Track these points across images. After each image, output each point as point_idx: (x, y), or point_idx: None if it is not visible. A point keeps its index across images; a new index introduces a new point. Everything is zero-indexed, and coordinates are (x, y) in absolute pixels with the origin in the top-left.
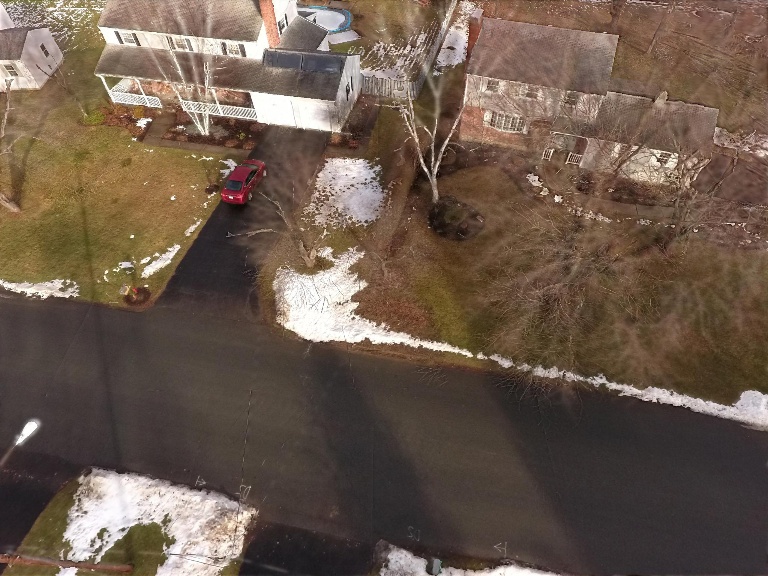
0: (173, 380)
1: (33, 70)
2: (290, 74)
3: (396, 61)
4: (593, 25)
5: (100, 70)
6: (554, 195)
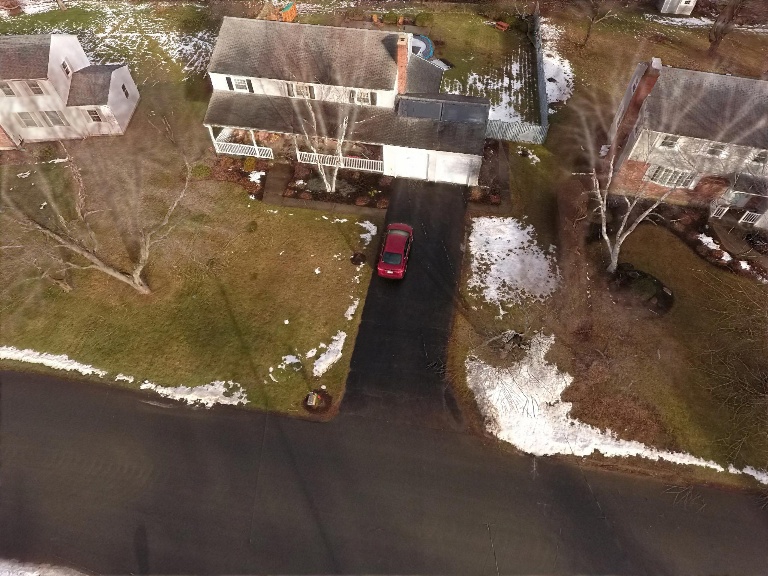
0: (393, 514)
1: (117, 114)
2: (428, 125)
3: (500, 96)
4: (689, 52)
5: (210, 120)
6: (738, 261)
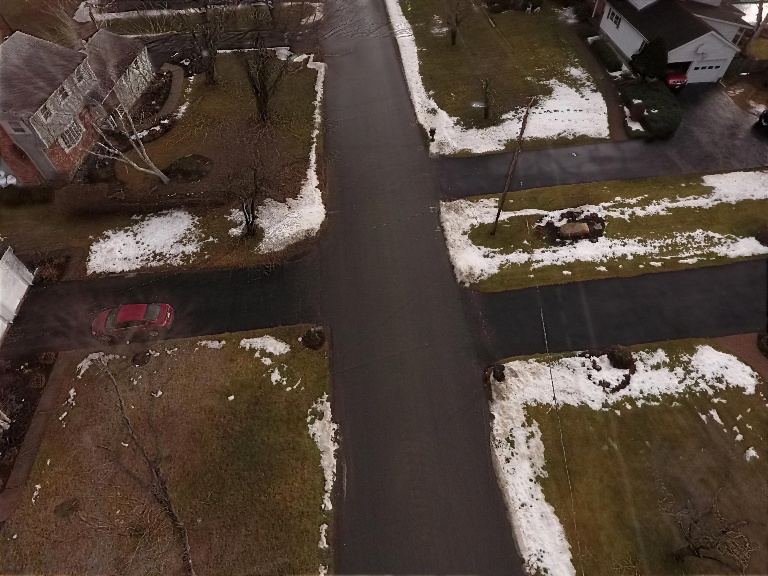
0: (383, 271)
1: None
2: None
3: None
4: None
5: None
6: None
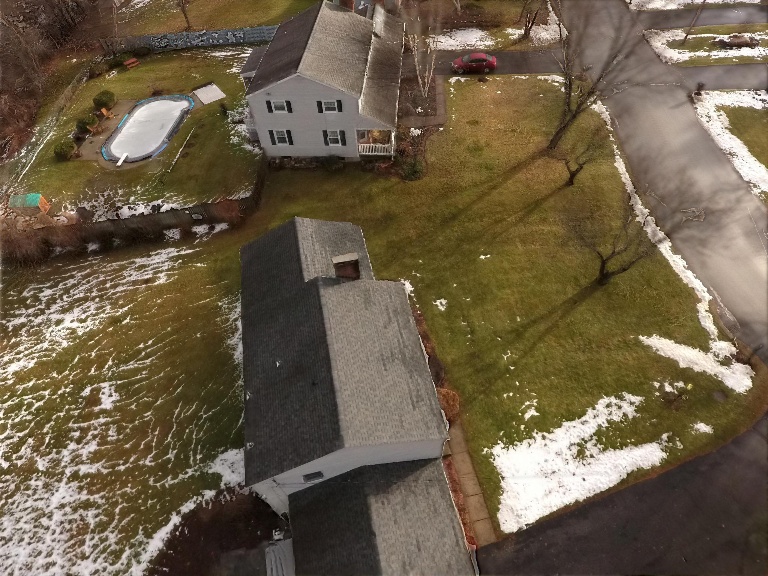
0: None
1: None
2: (386, 30)
3: None
4: None
5: (392, 123)
6: None
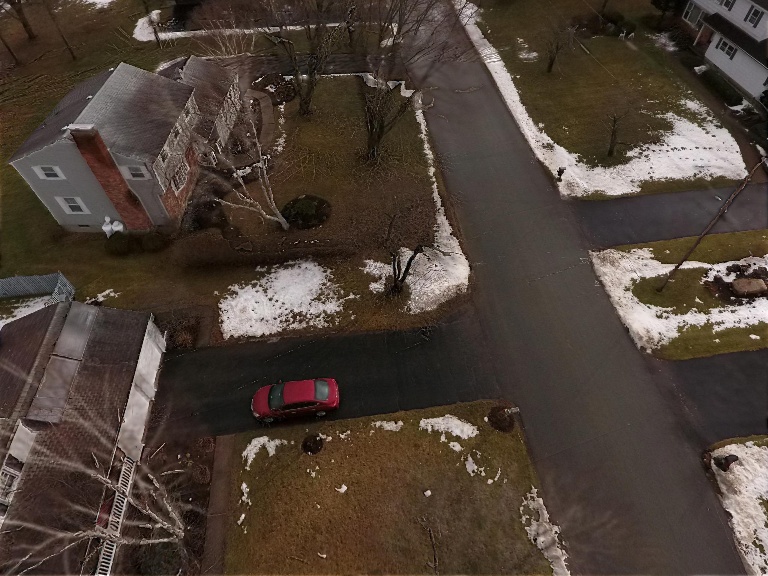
0: (554, 335)
1: None
2: (85, 378)
3: None
4: None
5: None
6: None
